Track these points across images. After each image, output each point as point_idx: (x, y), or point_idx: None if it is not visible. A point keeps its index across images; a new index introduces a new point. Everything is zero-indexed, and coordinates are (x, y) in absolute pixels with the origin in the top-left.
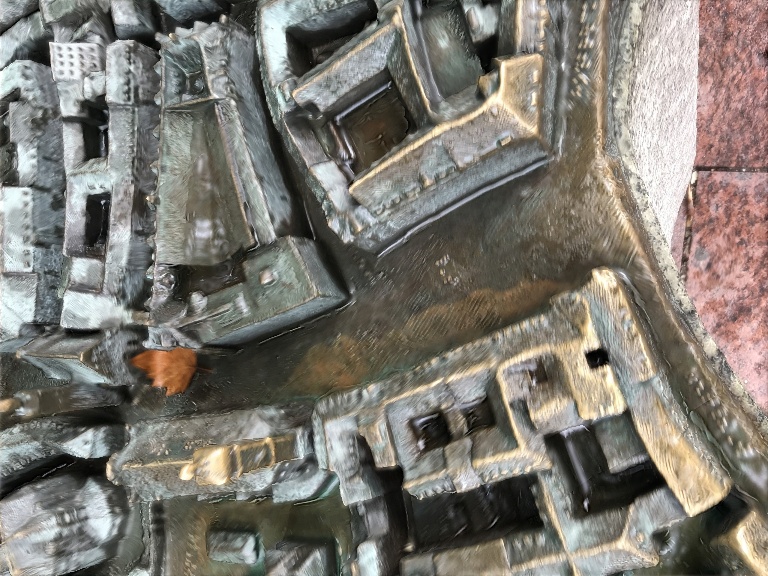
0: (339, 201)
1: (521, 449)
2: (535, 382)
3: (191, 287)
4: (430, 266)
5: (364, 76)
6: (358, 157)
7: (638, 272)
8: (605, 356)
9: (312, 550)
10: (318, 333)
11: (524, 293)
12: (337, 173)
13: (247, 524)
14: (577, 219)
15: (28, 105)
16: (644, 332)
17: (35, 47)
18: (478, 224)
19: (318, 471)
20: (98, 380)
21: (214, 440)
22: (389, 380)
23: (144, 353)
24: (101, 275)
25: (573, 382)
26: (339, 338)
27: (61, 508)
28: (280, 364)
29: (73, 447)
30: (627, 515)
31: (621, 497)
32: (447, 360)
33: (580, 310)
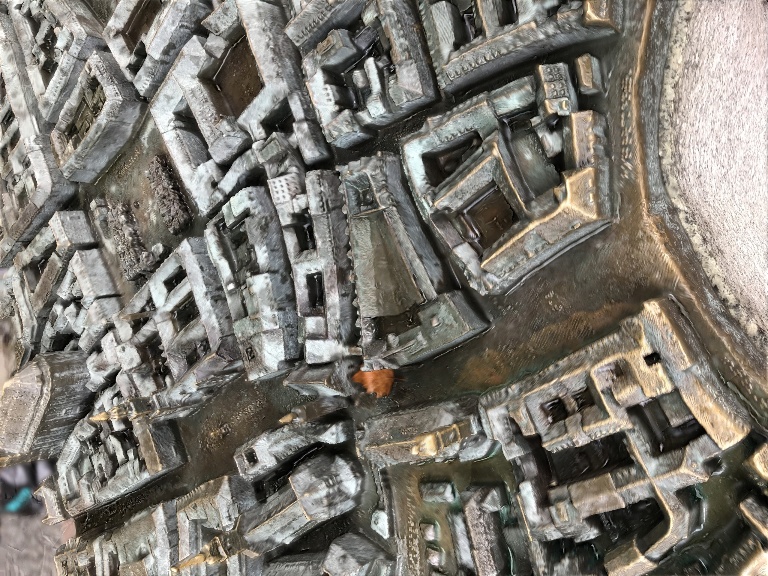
0: (475, 270)
1: (612, 418)
2: (615, 376)
3: (385, 330)
4: (541, 299)
5: (479, 187)
6: (482, 235)
7: (682, 293)
8: (658, 356)
9: (490, 489)
10: (472, 349)
11: (607, 312)
12: (471, 250)
13: (444, 477)
14: (636, 261)
15: (256, 218)
16: (685, 337)
17: (249, 174)
18: (570, 269)
19: (486, 440)
20: (334, 394)
21: (419, 427)
22: (524, 381)
23: (358, 372)
24: (324, 326)
25: (638, 375)
26: (487, 352)
27: (326, 476)
28: (450, 372)
29: (326, 438)
30: (685, 452)
31: (681, 441)
32: (559, 366)
33: (638, 330)
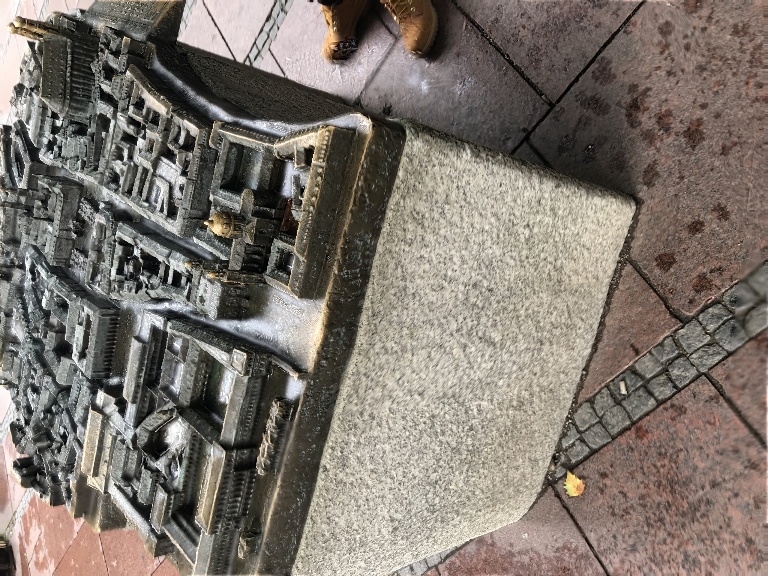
0: None
1: None
2: None
3: None
4: None
5: None
6: None
7: None
8: None
9: None
10: None
11: None
12: None
13: None
14: None
15: None
16: None
17: None
18: None
19: None
20: None
21: None
22: (4, 331)
23: None
24: None
25: None
26: None
27: None
28: None
29: None
30: None
31: None
32: (1, 342)
33: None
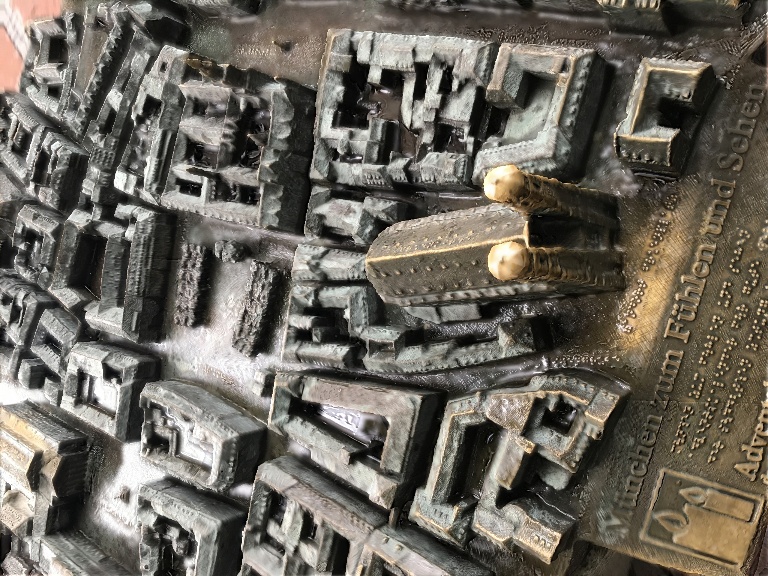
0: None
1: None
2: None
3: None
4: None
5: None
6: None
7: None
8: None
9: None
10: None
11: None
12: None
13: None
14: None
15: None
16: None
17: None
18: None
19: None
20: None
21: None
22: None
23: None
24: None
25: None
26: None
27: None
28: None
29: None
30: None
31: None
32: None
33: None
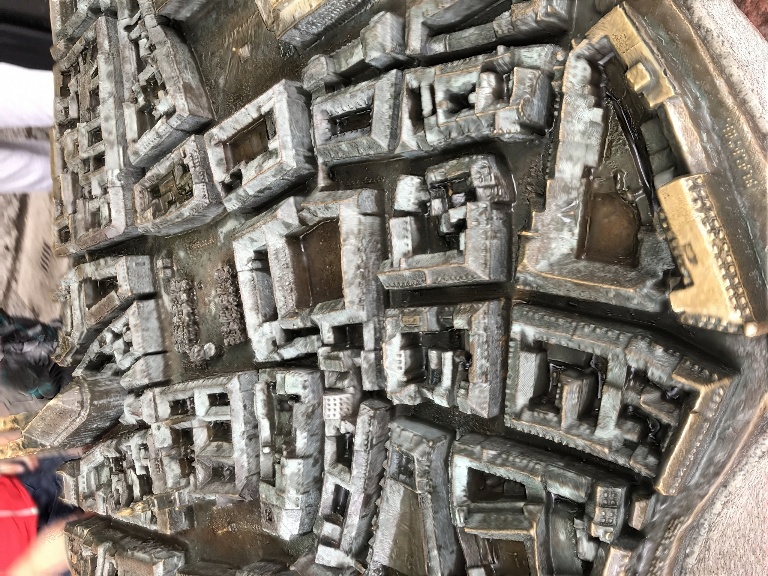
0: None
1: None
2: None
3: (391, 575)
4: None
5: (509, 538)
6: (500, 561)
7: None
8: None
9: None
10: None
11: None
12: None
13: None
14: None
15: (304, 405)
16: None
17: None
18: None
19: None
20: None
21: None
22: None
23: None
24: (339, 534)
25: None
26: None
27: None
28: None
29: None
30: None
31: None
32: None
33: None
